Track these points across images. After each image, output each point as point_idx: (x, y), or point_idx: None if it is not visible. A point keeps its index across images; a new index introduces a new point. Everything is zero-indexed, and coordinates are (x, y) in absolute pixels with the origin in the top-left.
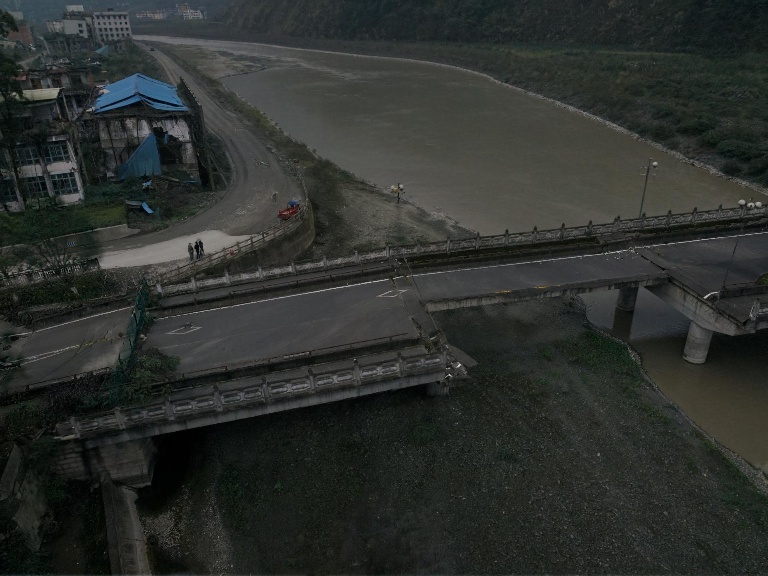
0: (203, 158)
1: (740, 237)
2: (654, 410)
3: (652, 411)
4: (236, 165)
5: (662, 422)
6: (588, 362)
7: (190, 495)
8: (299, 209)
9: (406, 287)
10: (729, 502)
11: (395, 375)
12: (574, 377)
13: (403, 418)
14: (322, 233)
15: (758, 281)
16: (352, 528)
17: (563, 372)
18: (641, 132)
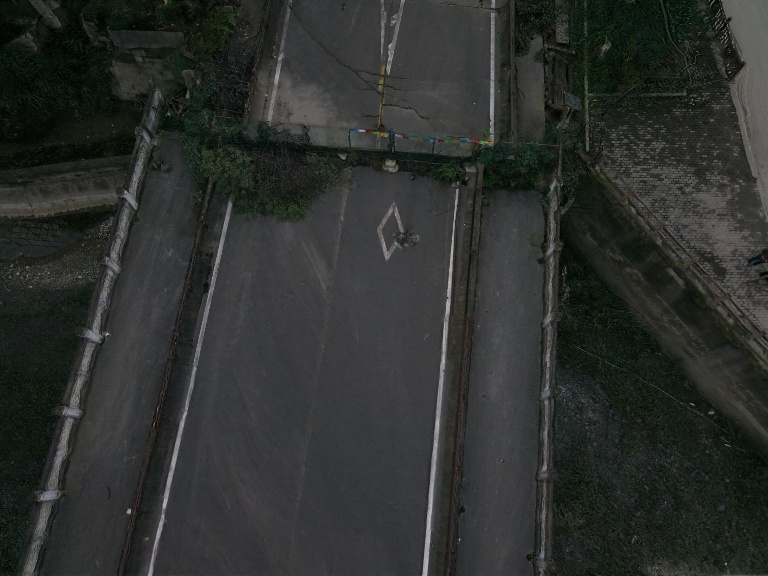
0: None
1: None
2: None
3: None
4: None
5: None
6: None
7: None
8: None
9: None
10: None
11: None
12: None
13: None
14: None
15: None
16: None
17: None
18: None
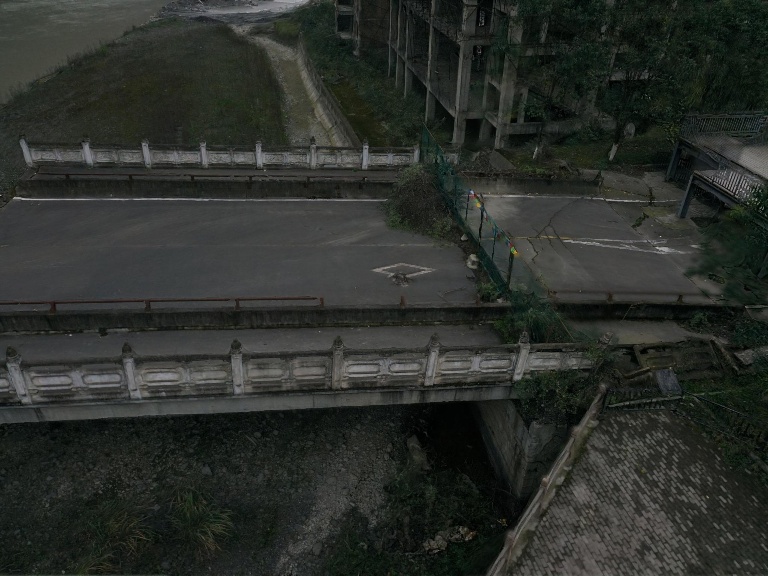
0: None
1: None
2: None
3: None
4: None
5: None
6: None
7: None
8: None
9: None
10: None
11: (100, 164)
12: None
13: None
14: None
15: None
16: None
17: None
18: None
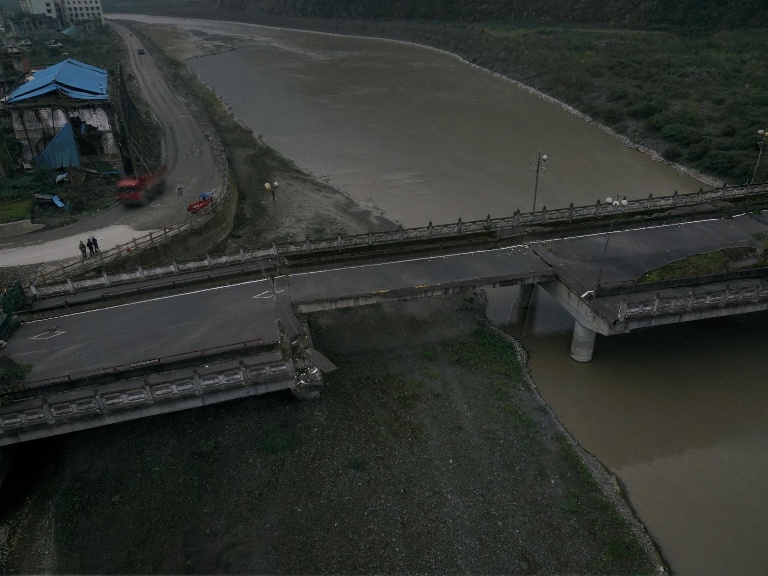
0: (125, 148)
1: (639, 230)
2: (520, 413)
3: (518, 414)
4: (168, 154)
5: (525, 426)
6: (469, 362)
7: (31, 508)
8: (211, 202)
9: (283, 287)
10: (568, 510)
11: (240, 383)
12: (451, 378)
13: (263, 424)
14: (241, 225)
15: (640, 278)
16: (178, 543)
17: (441, 373)
18: (593, 115)
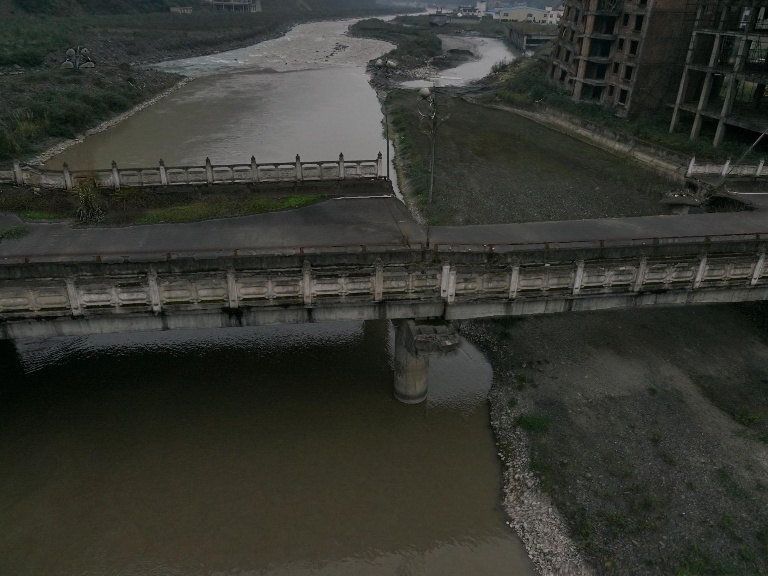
0: None
1: None
2: None
3: None
4: None
5: None
6: None
7: None
8: None
9: None
10: None
11: (727, 176)
12: None
13: None
14: None
15: None
16: None
17: None
18: None
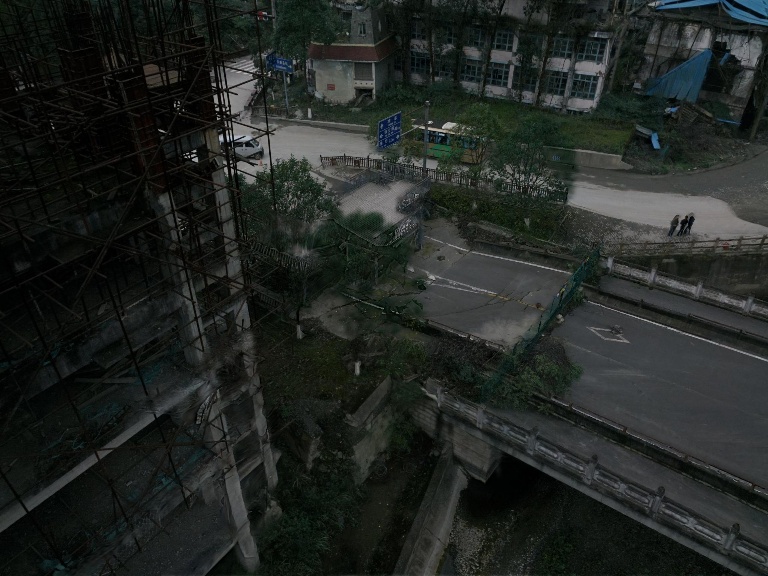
0: (760, 94)
1: None
2: None
3: None
4: None
5: None
6: None
7: (513, 528)
8: None
9: None
10: None
11: None
12: None
13: None
14: None
15: None
16: None
17: None
18: None
